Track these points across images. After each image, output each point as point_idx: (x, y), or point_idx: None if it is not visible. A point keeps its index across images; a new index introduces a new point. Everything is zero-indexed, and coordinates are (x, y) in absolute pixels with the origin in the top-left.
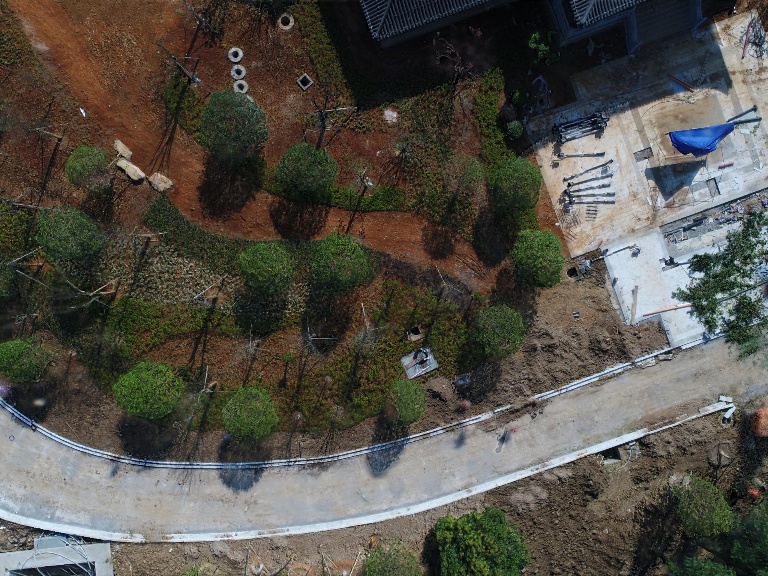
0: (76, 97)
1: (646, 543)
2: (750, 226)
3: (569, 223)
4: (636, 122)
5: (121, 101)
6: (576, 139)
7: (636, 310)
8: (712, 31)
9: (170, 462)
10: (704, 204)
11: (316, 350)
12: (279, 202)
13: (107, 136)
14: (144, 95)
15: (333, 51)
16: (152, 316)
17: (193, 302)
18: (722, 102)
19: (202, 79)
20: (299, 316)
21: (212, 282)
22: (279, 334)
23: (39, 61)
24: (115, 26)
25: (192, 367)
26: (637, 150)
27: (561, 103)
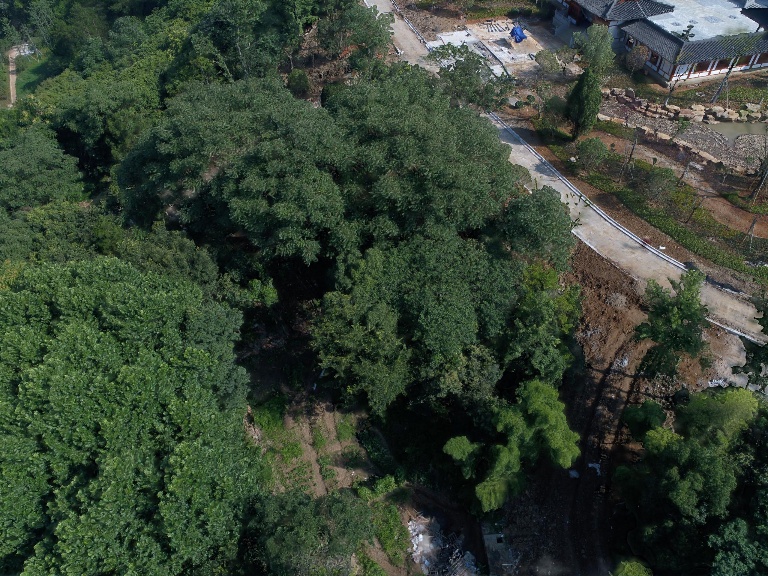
0: None
1: None
2: None
3: None
4: None
5: None
6: None
7: None
8: None
9: None
10: None
11: None
12: None
13: None
14: None
15: None
16: None
17: None
18: None
19: None
20: None
21: None
22: None
23: None
24: None
25: None
26: None
27: None
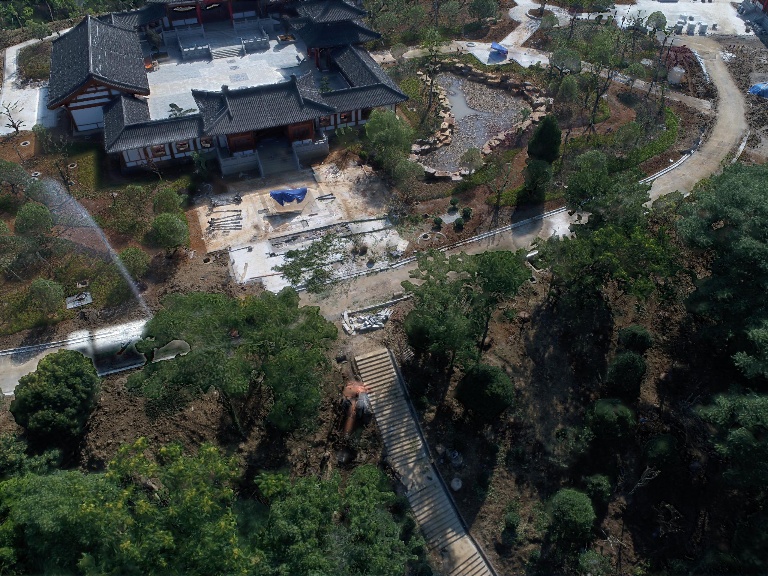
0: None
1: (228, 422)
2: (327, 239)
3: (210, 238)
4: (261, 200)
5: None
6: (224, 206)
7: (245, 276)
8: (310, 170)
9: None
10: (298, 230)
11: (6, 288)
12: None
13: None
14: None
15: (92, 173)
16: None
17: None
18: (313, 192)
19: None
20: None
21: None
22: None
23: None
24: None
25: None
26: (260, 210)
27: (219, 193)
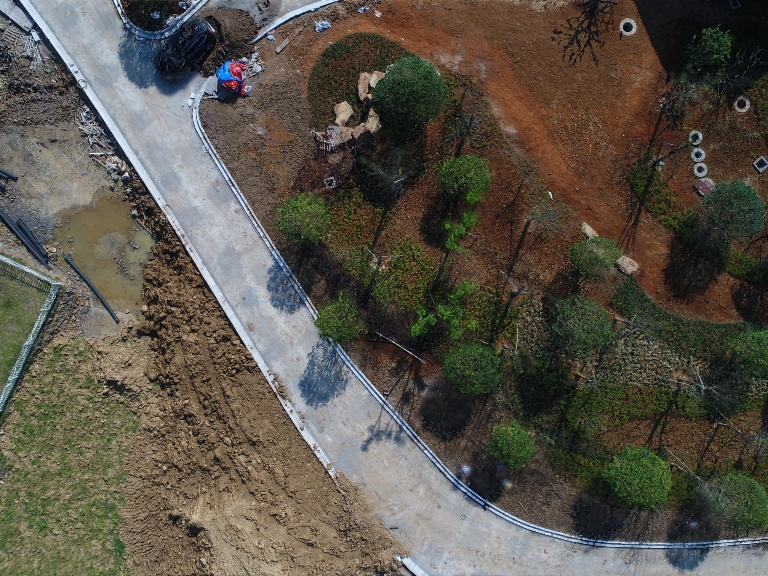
0: (543, 180)
1: None
2: None
3: None
4: None
5: (587, 184)
6: None
7: None
8: None
9: (620, 542)
10: None
11: None
12: (740, 285)
13: (574, 219)
14: (610, 178)
15: None
16: (617, 398)
17: (657, 384)
18: None
19: (665, 162)
20: (763, 399)
21: (677, 365)
22: (740, 416)
23: (508, 144)
24: (581, 109)
25: (649, 448)
26: None
27: None
